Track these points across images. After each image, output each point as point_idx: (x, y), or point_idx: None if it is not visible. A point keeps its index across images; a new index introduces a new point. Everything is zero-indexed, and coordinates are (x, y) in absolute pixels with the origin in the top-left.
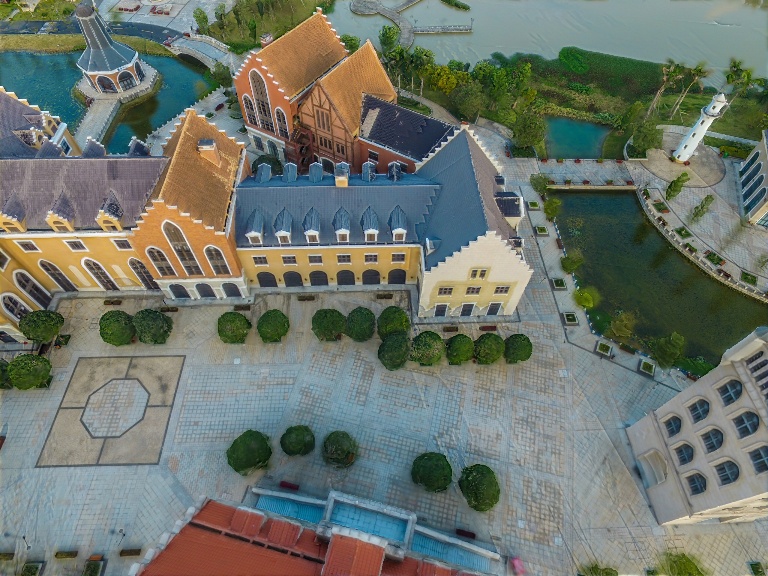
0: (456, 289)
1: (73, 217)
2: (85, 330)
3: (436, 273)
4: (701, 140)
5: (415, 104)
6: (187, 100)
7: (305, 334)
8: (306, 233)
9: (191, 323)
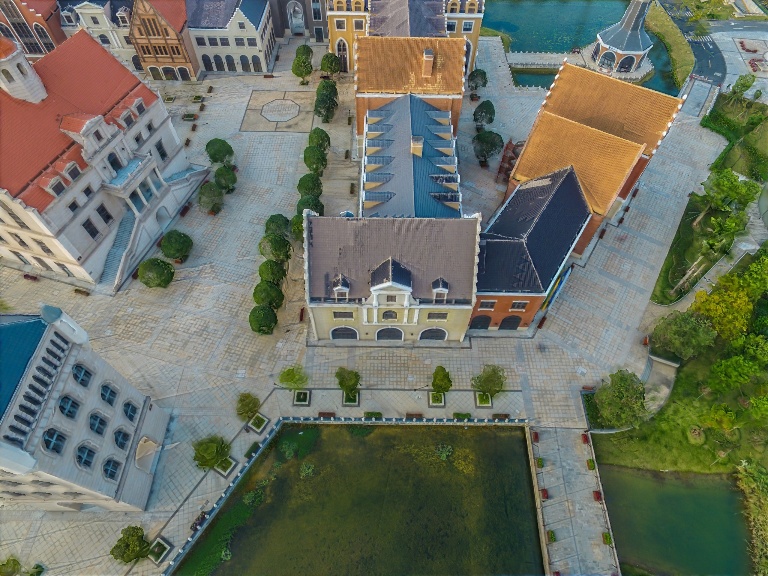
0: None
1: (375, 29)
2: (339, 90)
3: None
4: None
5: (672, 286)
6: None
7: None
8: None
9: (337, 132)
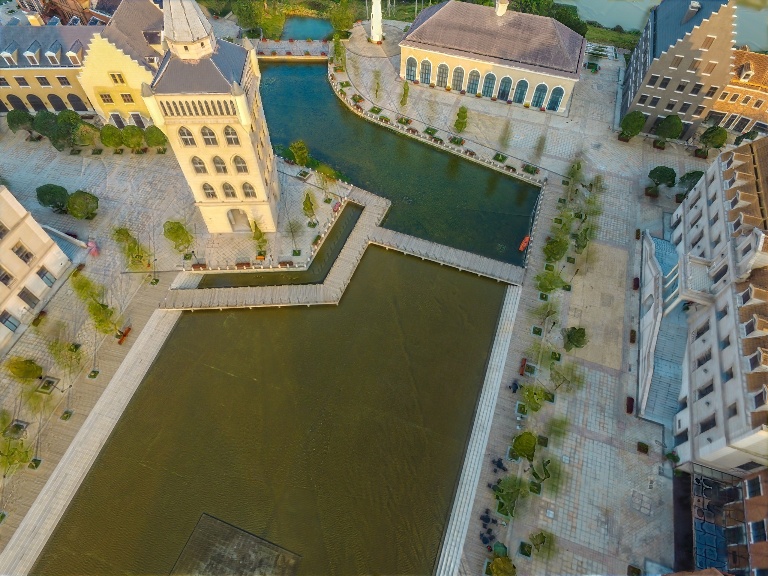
0: (114, 97)
1: None
2: None
3: (85, 77)
4: (403, 29)
5: None
6: (1, 4)
7: (16, 138)
8: (1, 54)
9: None
